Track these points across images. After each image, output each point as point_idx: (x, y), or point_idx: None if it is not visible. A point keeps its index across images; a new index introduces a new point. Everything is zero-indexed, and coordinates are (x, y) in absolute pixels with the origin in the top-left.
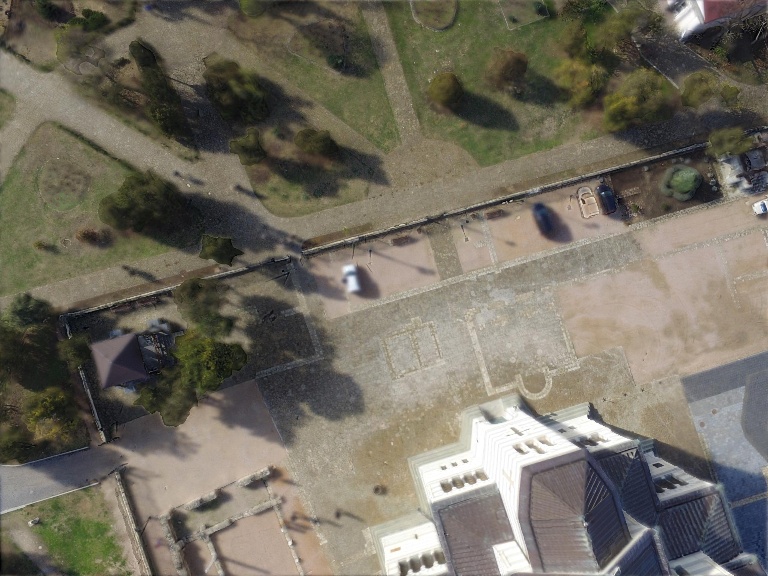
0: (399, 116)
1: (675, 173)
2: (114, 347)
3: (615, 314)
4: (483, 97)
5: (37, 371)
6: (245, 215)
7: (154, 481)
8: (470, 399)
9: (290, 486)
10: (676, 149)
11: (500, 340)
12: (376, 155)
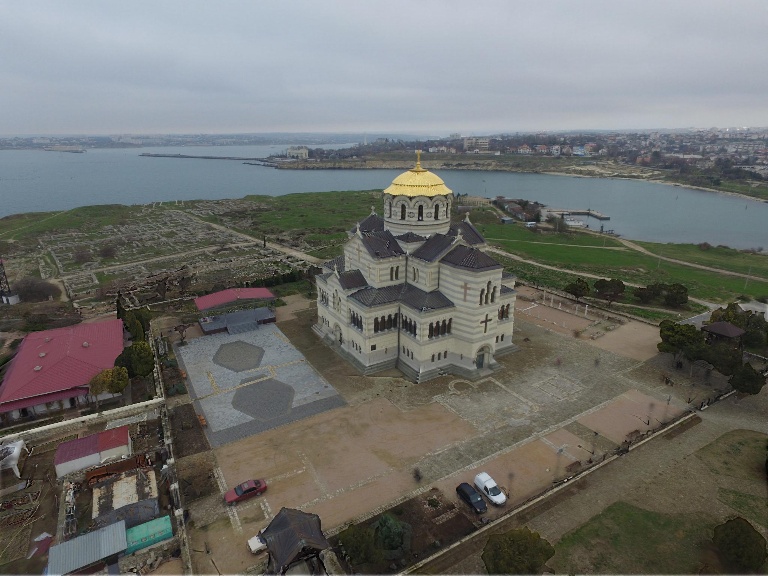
0: (753, 525)
1: (400, 544)
2: (733, 330)
3: (417, 428)
4: (692, 575)
5: (759, 348)
6: (766, 425)
7: (644, 329)
8: (502, 374)
9: (575, 336)
10: (406, 575)
11: (502, 401)
12: (728, 485)
